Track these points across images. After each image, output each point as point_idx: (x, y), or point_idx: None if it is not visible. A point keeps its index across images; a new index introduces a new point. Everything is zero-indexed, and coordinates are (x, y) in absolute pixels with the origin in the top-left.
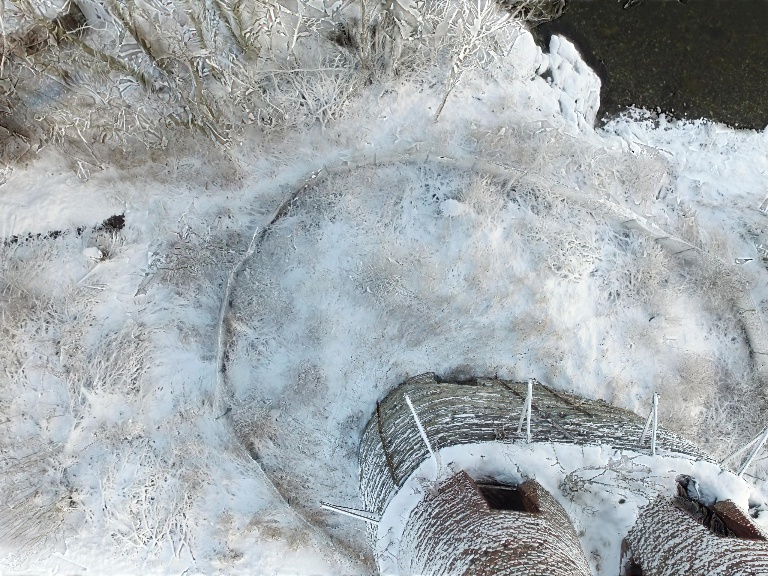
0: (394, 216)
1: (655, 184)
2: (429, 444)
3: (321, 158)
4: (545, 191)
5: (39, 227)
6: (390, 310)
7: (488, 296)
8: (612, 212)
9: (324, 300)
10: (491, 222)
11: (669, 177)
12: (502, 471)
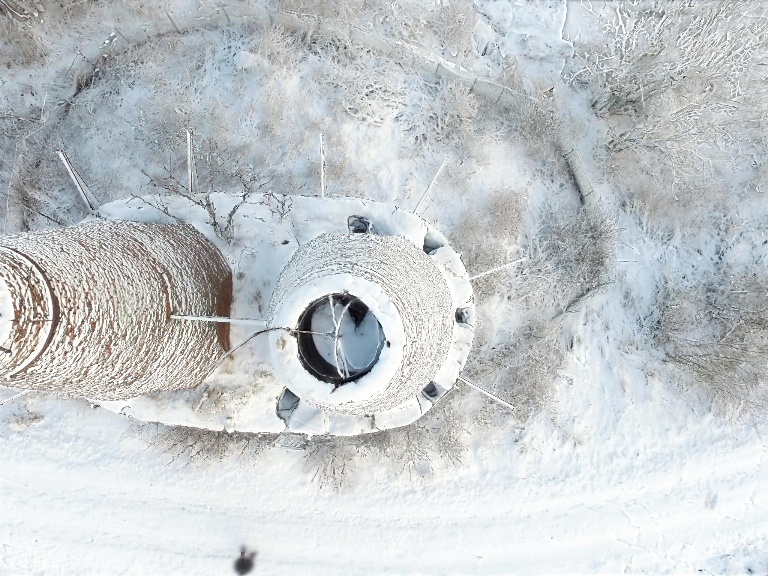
0: (194, 78)
1: (480, 41)
2: (87, 201)
3: (125, 31)
4: (345, 40)
5: None
6: (182, 163)
7: (283, 143)
8: (417, 58)
9: (116, 159)
10: (287, 72)
11: (496, 34)
12: (159, 220)
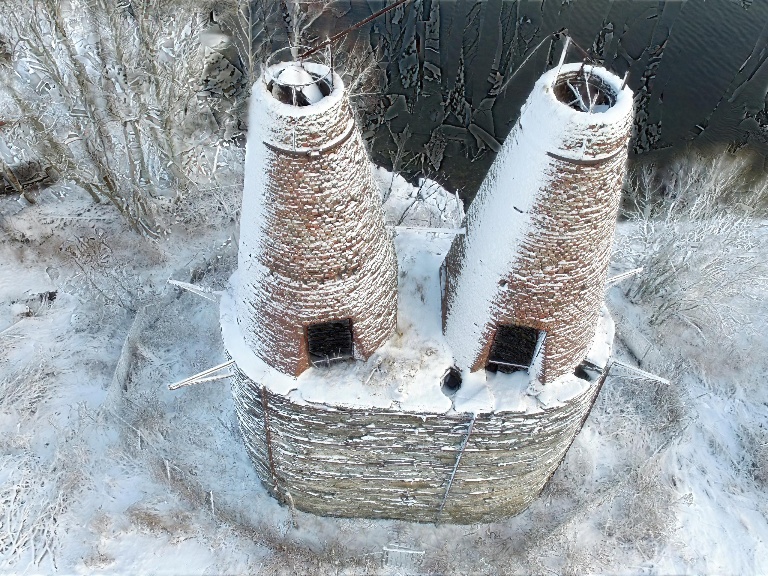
0: None
1: None
2: None
3: None
4: None
5: None
6: None
7: None
8: None
9: None
10: None
11: None
12: None
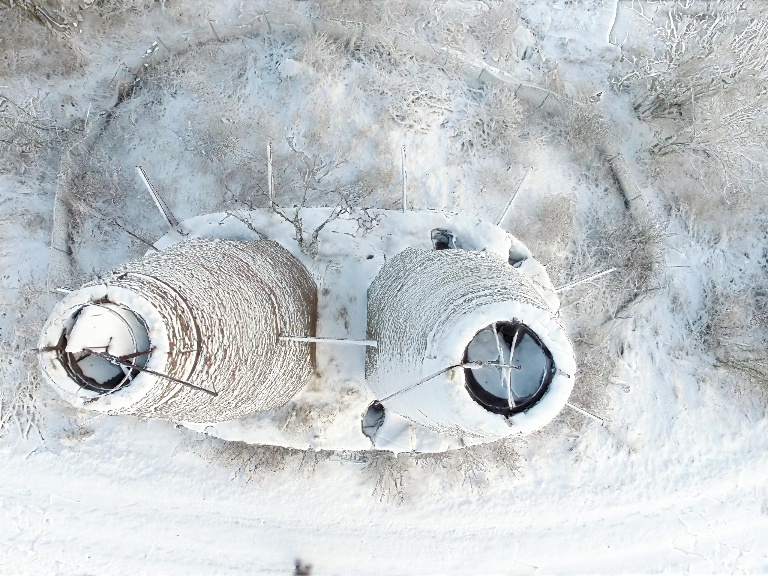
0: (237, 86)
1: (519, 45)
2: (166, 217)
3: (164, 39)
4: (389, 46)
5: None
6: (229, 173)
7: (330, 152)
8: (461, 63)
9: (162, 170)
10: (332, 80)
11: (535, 38)
12: (241, 236)
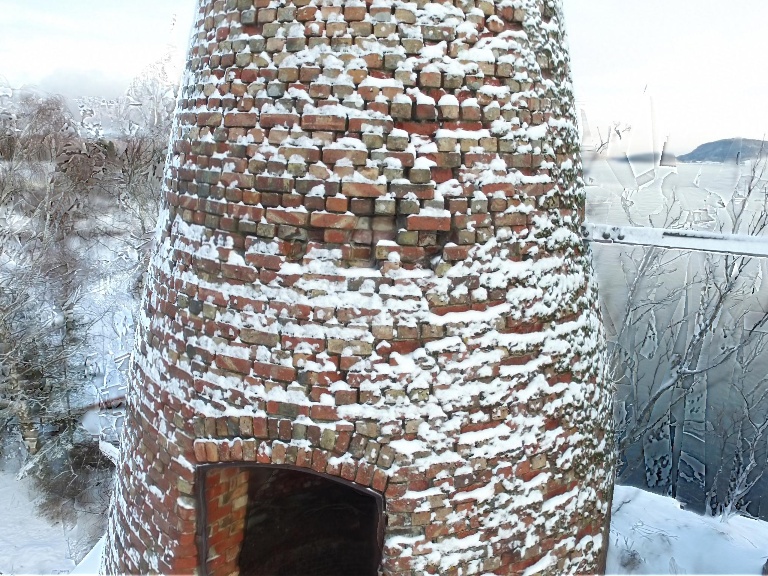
0: None
1: None
2: None
3: None
4: None
5: (8, 568)
6: None
7: None
8: None
9: None
10: None
11: None
12: None
